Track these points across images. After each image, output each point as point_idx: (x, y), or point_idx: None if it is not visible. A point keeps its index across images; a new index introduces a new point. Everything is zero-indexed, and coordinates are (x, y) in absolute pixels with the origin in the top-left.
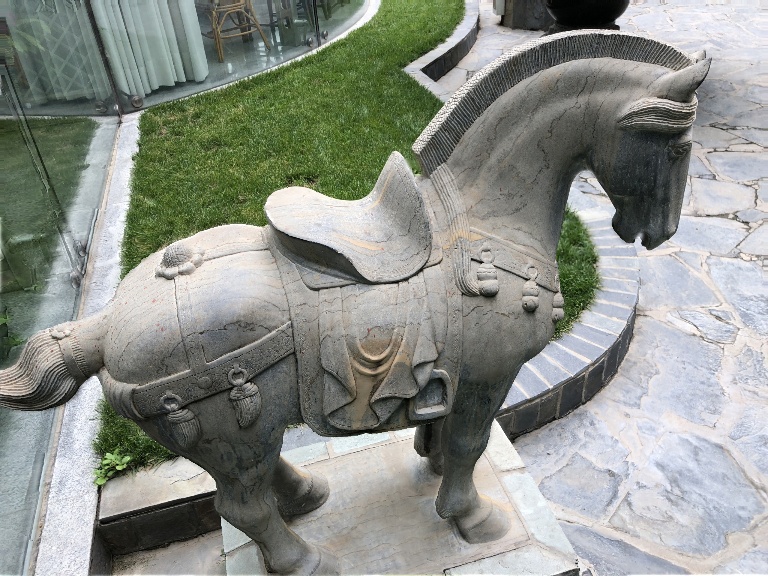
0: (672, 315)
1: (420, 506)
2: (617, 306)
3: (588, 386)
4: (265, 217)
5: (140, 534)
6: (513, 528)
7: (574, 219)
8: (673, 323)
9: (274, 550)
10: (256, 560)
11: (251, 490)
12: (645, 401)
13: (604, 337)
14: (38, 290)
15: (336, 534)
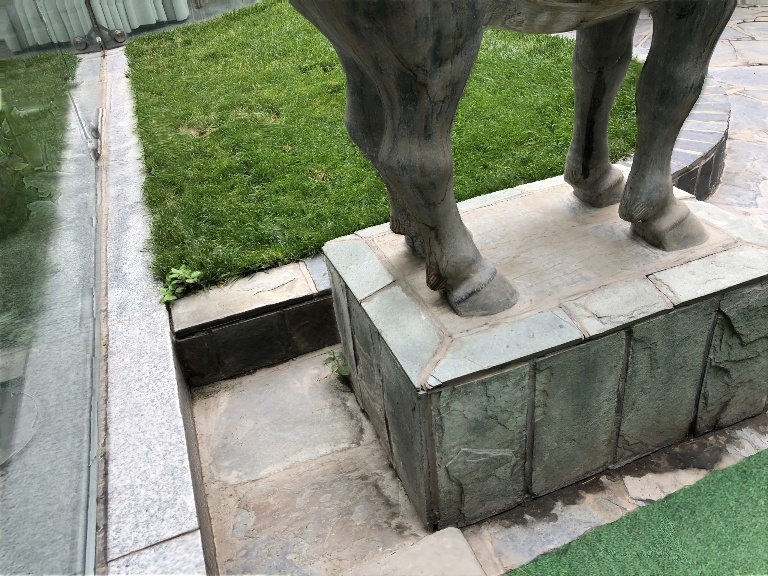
0: (759, 136)
1: (589, 231)
2: (711, 113)
3: (698, 188)
4: (292, 93)
5: (222, 355)
6: (713, 235)
7: (632, 61)
8: (763, 141)
9: (448, 240)
10: (404, 296)
11: (438, 112)
12: (761, 201)
13: (709, 135)
14: (50, 169)
15: (496, 263)
